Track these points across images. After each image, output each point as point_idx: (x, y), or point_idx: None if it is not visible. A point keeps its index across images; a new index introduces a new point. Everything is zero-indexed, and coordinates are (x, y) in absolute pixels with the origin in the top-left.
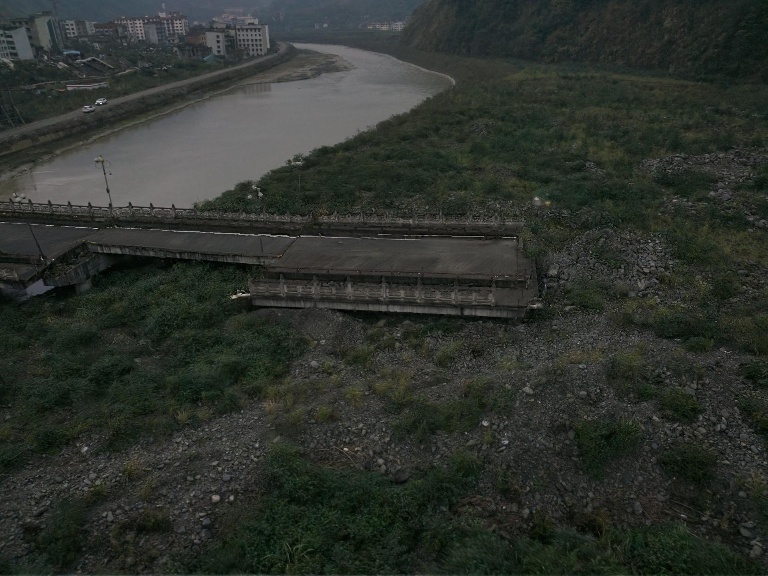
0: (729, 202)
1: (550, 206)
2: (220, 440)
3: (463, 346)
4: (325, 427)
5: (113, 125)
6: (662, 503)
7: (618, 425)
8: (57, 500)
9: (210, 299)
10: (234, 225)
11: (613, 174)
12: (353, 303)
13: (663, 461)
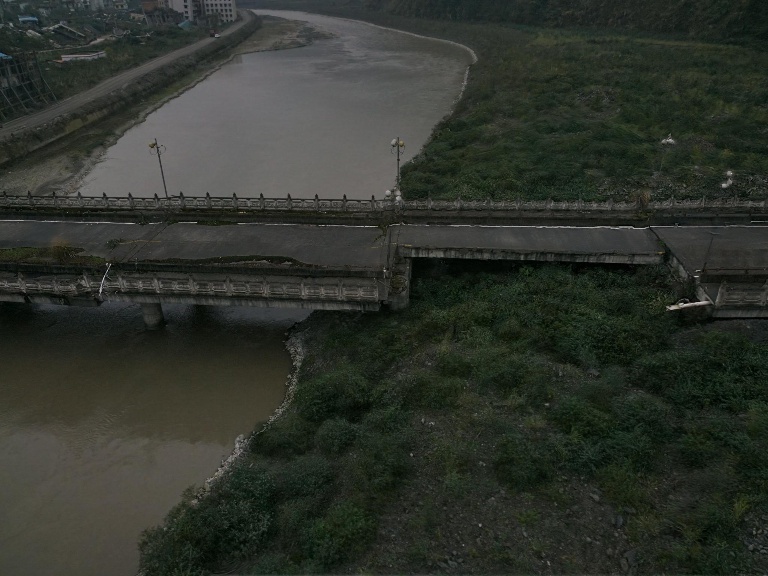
0: None
1: None
2: None
3: None
4: None
5: (149, 100)
6: None
7: None
8: None
9: (626, 311)
10: (560, 216)
11: None
12: None
13: None
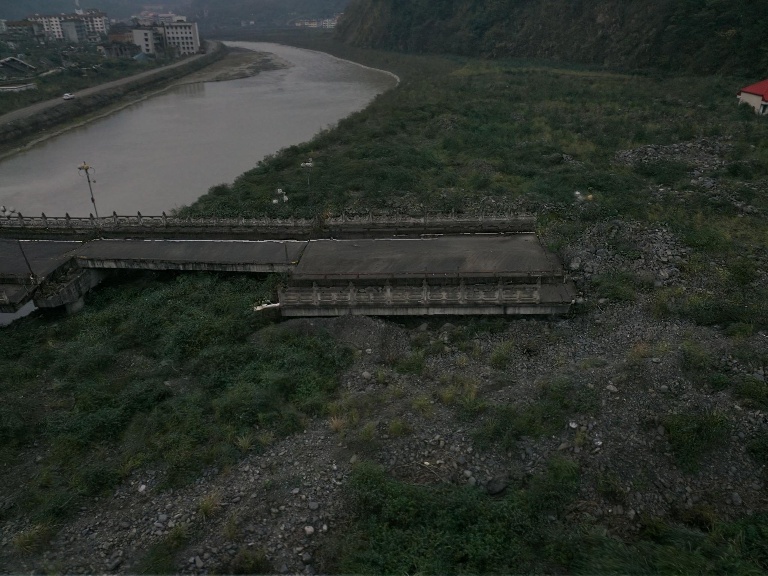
0: (713, 189)
1: (543, 199)
2: (292, 465)
3: (515, 346)
4: (401, 441)
5: (50, 129)
6: (758, 492)
7: (705, 417)
8: (130, 549)
9: (229, 312)
10: (236, 232)
11: (592, 166)
12: (391, 308)
13: (752, 449)
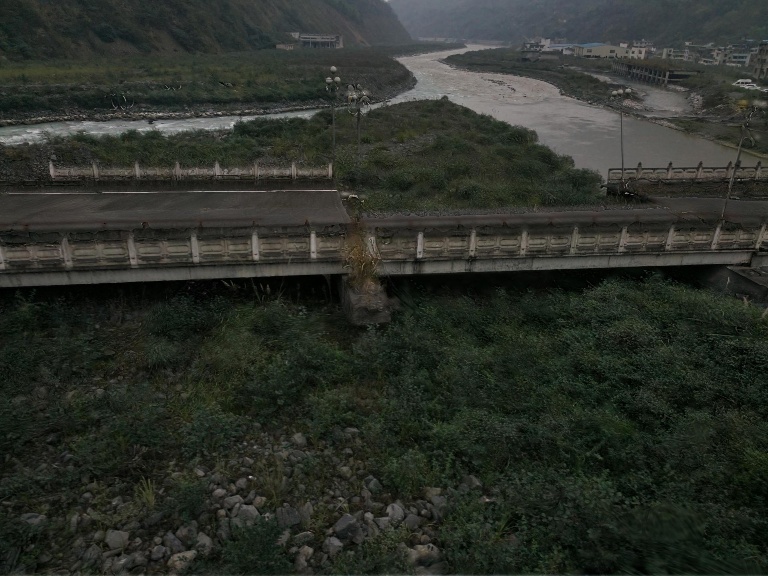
0: None
1: None
2: None
3: None
4: None
5: None
6: None
7: None
8: None
9: None
10: (494, 229)
11: None
12: None
13: None
